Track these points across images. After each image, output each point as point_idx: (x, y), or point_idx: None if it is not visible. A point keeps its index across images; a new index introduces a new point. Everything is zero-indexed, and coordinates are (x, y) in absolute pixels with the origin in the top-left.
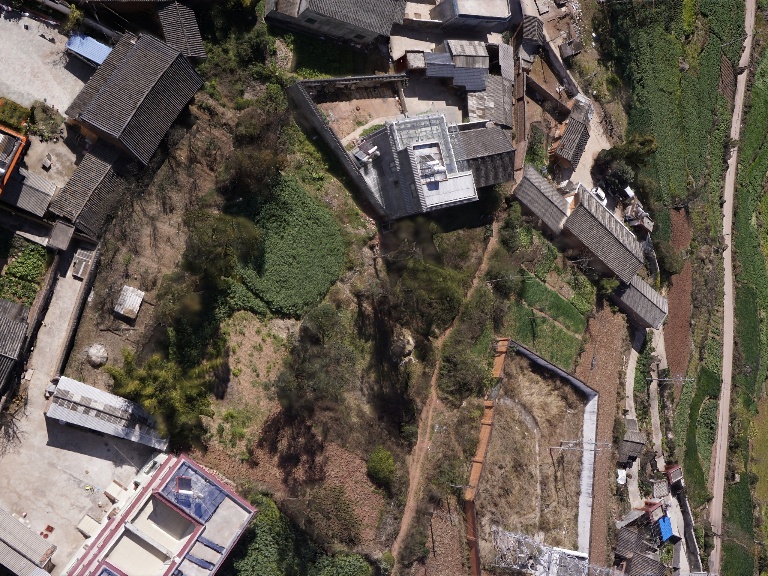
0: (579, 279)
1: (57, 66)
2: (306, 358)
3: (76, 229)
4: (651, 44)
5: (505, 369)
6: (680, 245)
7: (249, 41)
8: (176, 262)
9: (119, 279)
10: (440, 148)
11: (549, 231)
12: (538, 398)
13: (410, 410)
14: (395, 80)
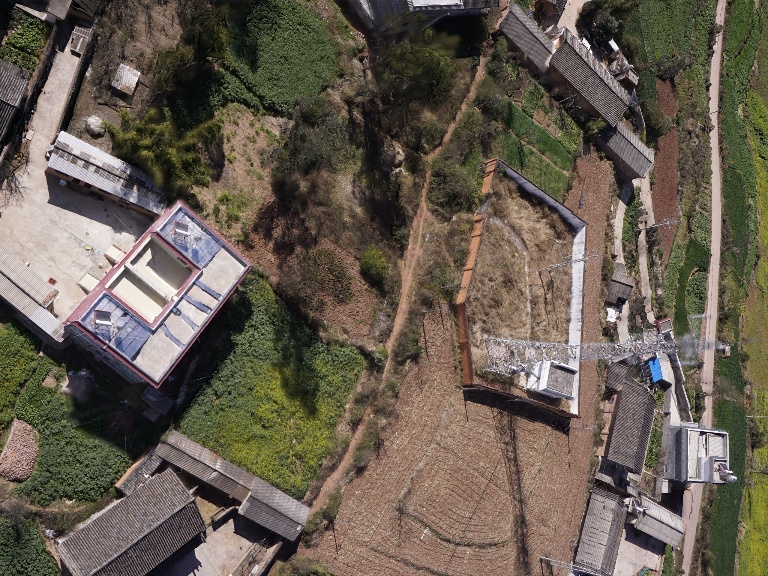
0: (566, 120)
1: None
2: (298, 136)
3: (73, 2)
4: None
5: (494, 188)
6: (666, 114)
7: None
8: None
9: (116, 59)
10: None
11: (535, 70)
12: (527, 223)
13: (401, 215)
14: None
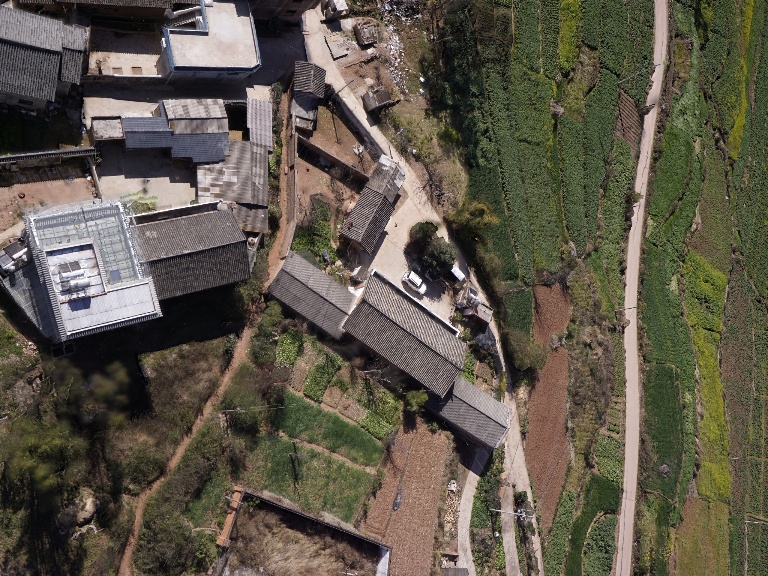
0: (376, 393)
1: None
2: None
3: None
4: (505, 87)
5: (238, 531)
6: (551, 329)
7: None
8: None
9: None
10: (95, 251)
11: (329, 335)
12: (297, 563)
13: None
14: (81, 155)
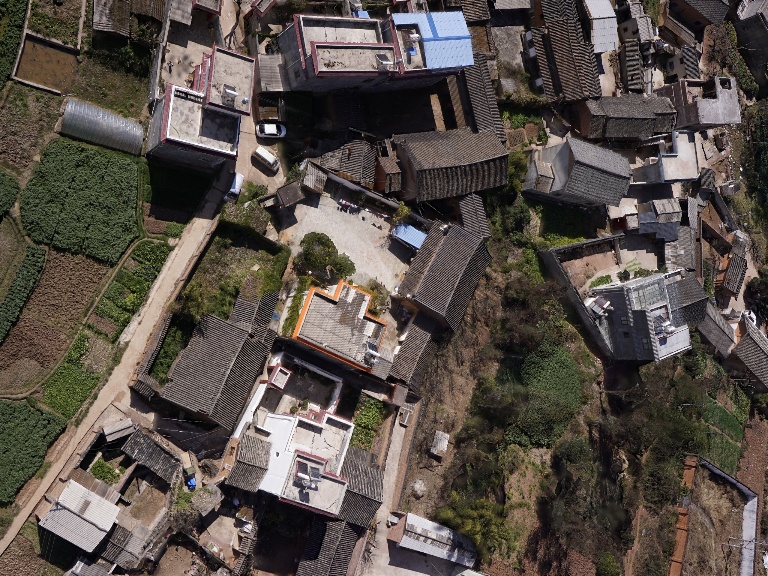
0: (738, 394)
1: (383, 248)
2: (575, 491)
3: (408, 389)
4: None
5: None
6: None
7: (514, 216)
8: (466, 406)
9: (431, 424)
10: None
11: (718, 354)
12: (713, 502)
13: (628, 520)
14: None
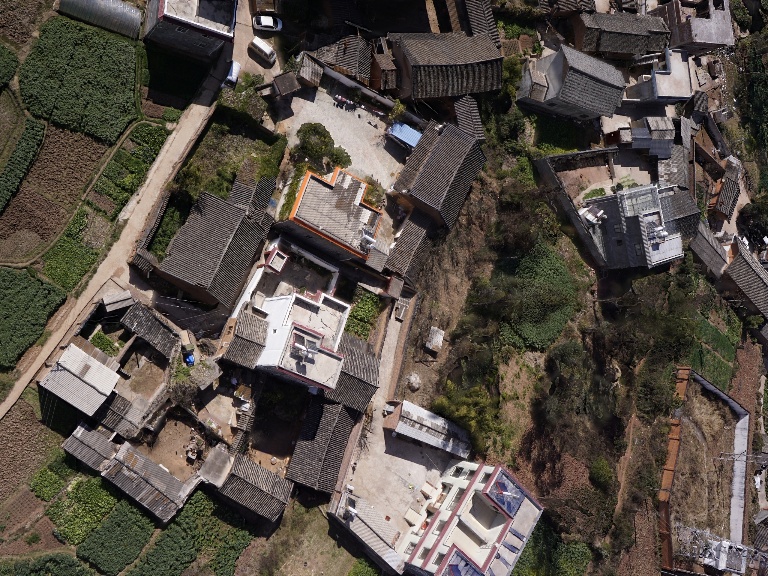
0: (731, 315)
1: (379, 147)
2: (569, 387)
3: (404, 282)
4: None
5: None
6: None
7: (509, 123)
8: (461, 306)
9: (426, 320)
10: (660, 216)
11: (711, 275)
12: (705, 417)
13: (621, 427)
14: (608, 152)
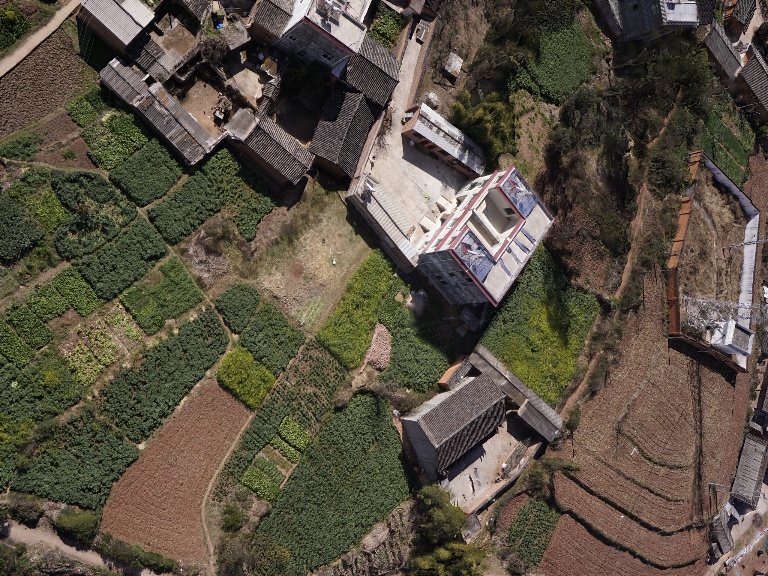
0: (744, 123)
1: None
2: (582, 120)
3: (425, 1)
4: None
5: None
6: None
7: None
8: (480, 44)
9: (445, 48)
10: None
11: (725, 79)
12: (716, 207)
13: (632, 191)
14: None
